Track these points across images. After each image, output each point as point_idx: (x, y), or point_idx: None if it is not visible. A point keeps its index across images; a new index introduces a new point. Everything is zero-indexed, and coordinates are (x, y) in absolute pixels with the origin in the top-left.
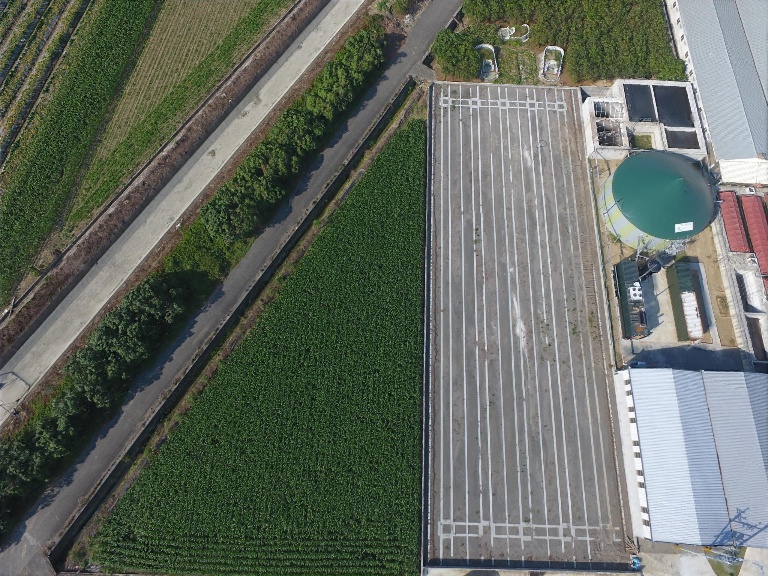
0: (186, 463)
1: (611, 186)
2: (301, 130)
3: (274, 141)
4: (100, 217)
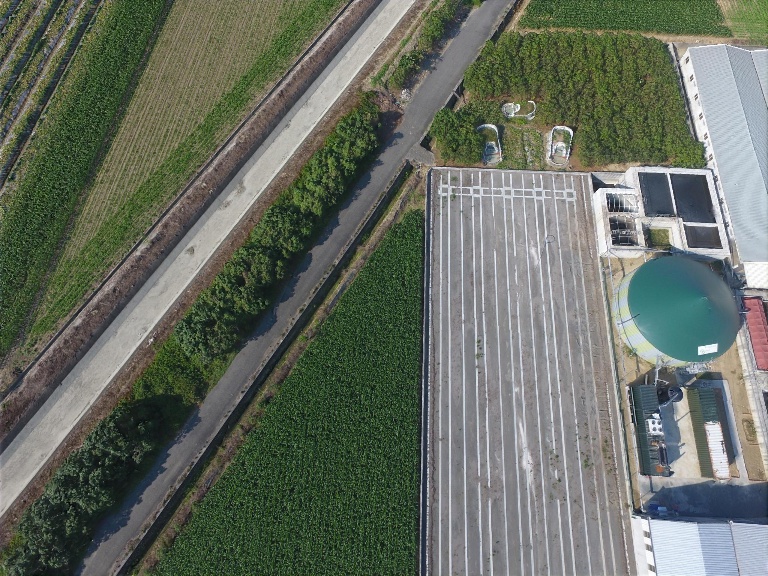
0: None
1: (627, 297)
2: (287, 232)
3: (257, 243)
4: (66, 328)
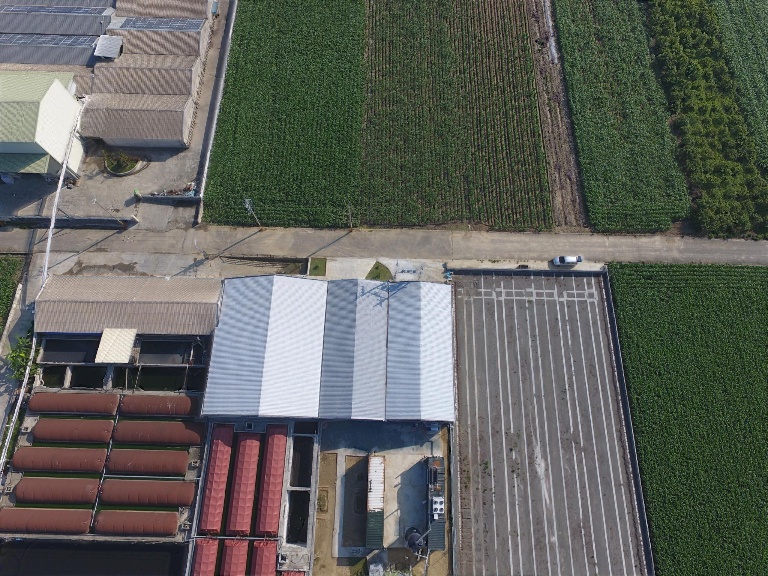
0: None
1: None
2: None
3: None
4: None
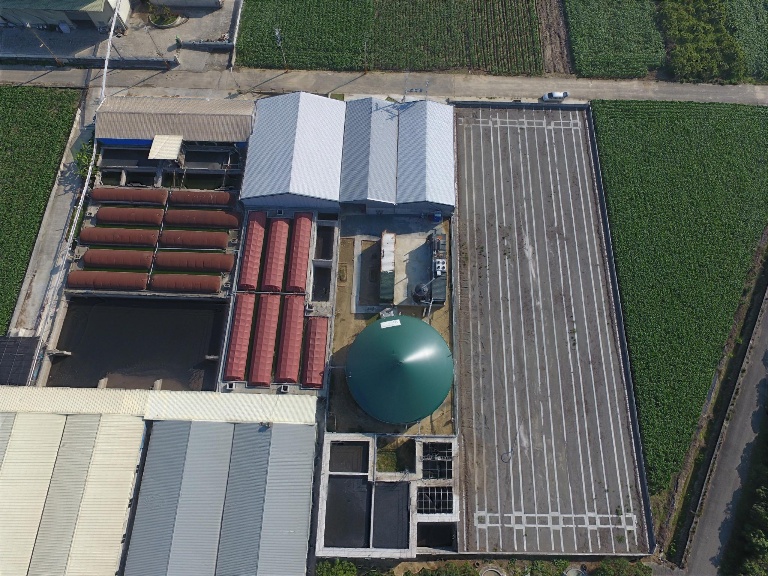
0: (765, 157)
1: None
2: None
3: None
4: None
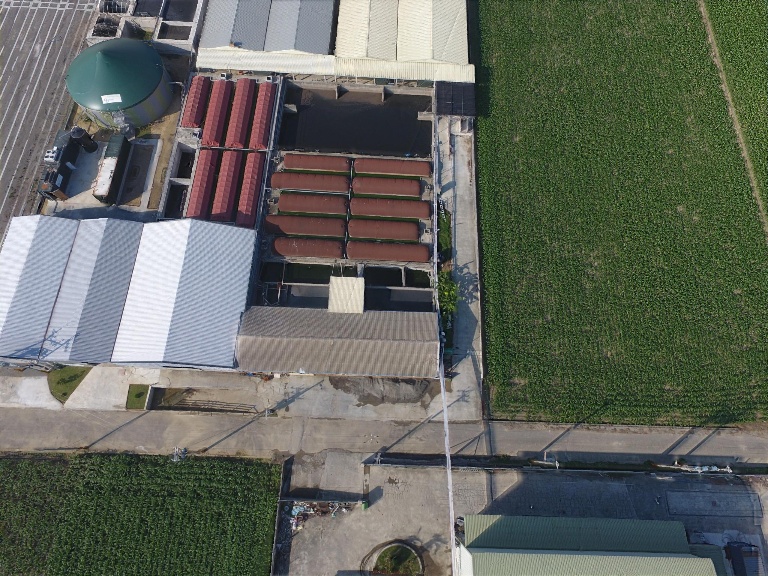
0: None
1: None
2: None
3: None
4: None
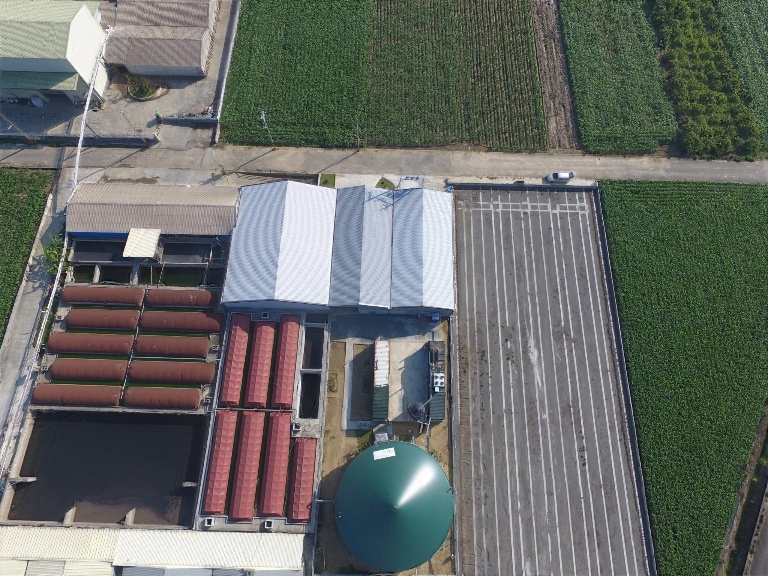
0: None
1: None
2: None
3: None
4: None
